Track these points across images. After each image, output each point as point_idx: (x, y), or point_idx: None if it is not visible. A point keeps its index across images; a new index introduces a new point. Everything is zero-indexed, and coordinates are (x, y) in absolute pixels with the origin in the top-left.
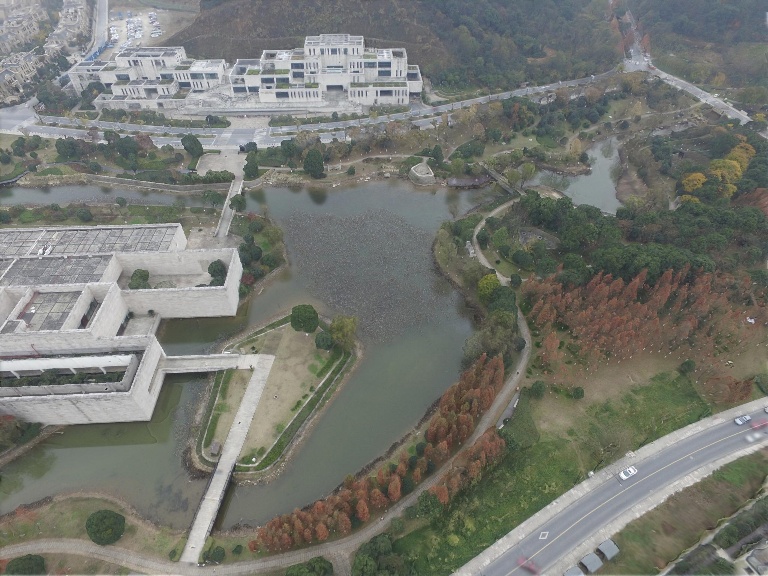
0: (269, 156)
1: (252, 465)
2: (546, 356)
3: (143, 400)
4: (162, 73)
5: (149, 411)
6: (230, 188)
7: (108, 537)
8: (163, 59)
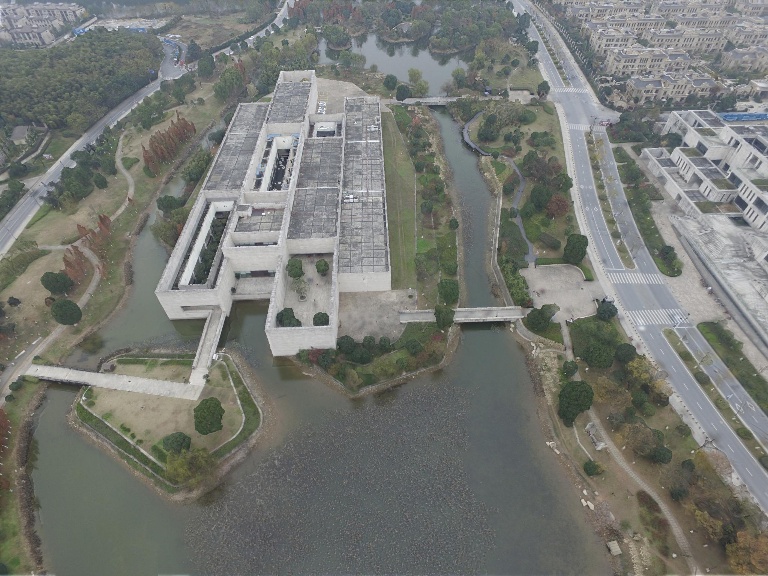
0: (596, 337)
1: (82, 398)
2: None
3: (170, 305)
4: (735, 173)
5: (173, 315)
6: (500, 307)
7: (52, 314)
8: (763, 161)
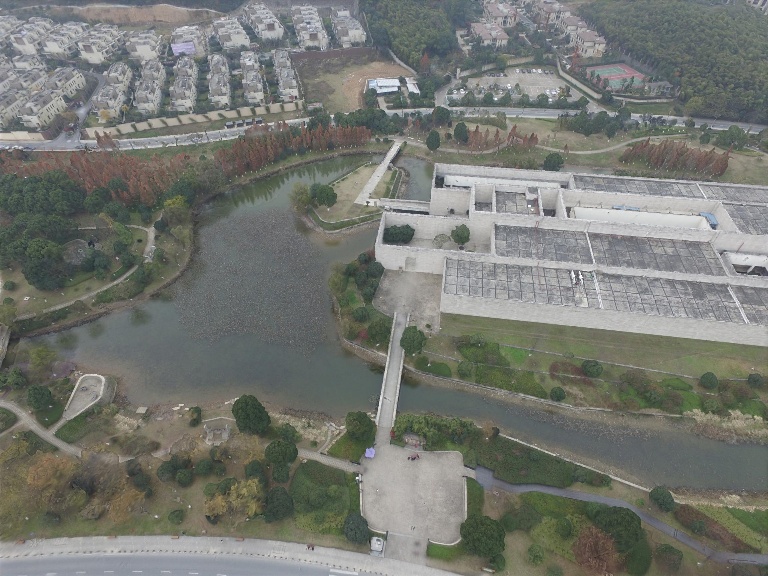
0: None
1: None
2: (188, 156)
3: None
4: None
5: None
6: None
7: None
8: None
